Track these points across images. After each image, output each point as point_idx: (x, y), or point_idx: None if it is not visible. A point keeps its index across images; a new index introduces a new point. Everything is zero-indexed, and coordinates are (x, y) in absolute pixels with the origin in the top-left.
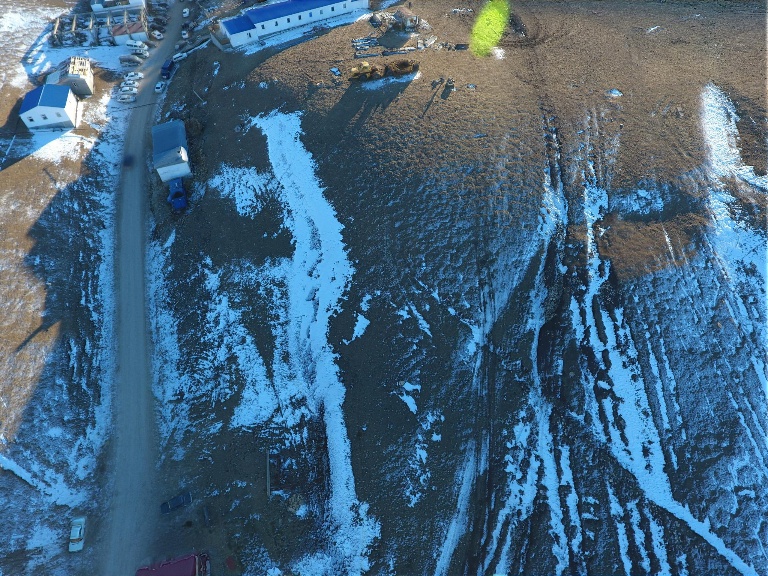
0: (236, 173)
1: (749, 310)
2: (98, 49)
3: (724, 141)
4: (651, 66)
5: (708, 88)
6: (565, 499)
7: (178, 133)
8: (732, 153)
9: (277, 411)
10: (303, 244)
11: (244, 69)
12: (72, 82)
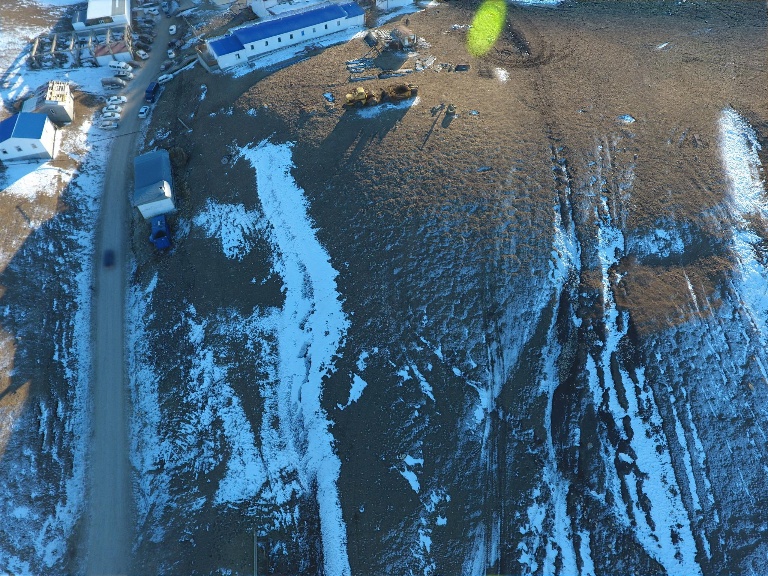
0: (223, 210)
1: None
2: (79, 71)
3: (746, 172)
4: (664, 88)
5: (726, 112)
6: None
7: (161, 165)
8: (755, 186)
9: (266, 485)
10: (294, 292)
11: (232, 94)
12: (50, 109)
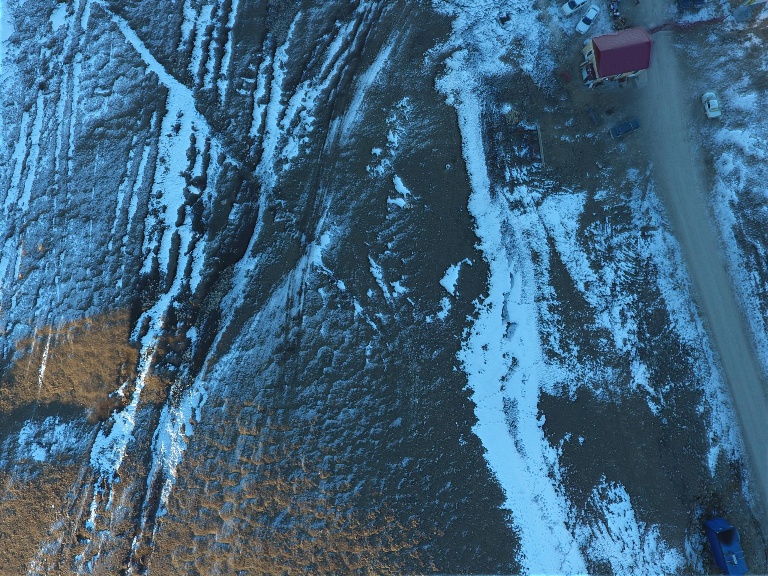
0: (645, 573)
1: None
2: None
3: None
4: None
5: None
6: (266, 94)
7: None
8: None
9: (538, 203)
10: (528, 411)
11: None
12: None
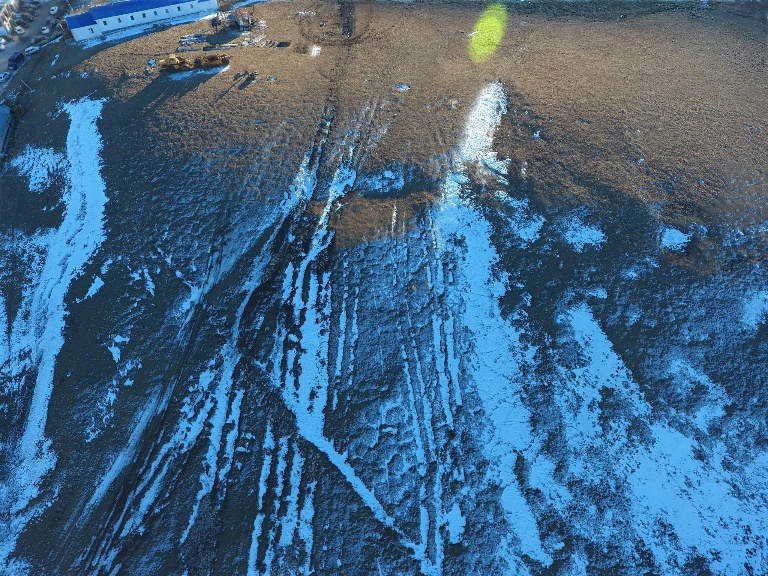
0: (36, 153)
1: (446, 275)
2: None
3: (484, 131)
4: (451, 65)
5: (491, 85)
6: (226, 435)
7: None
8: (486, 141)
9: (6, 363)
10: (71, 216)
11: (75, 61)
12: None
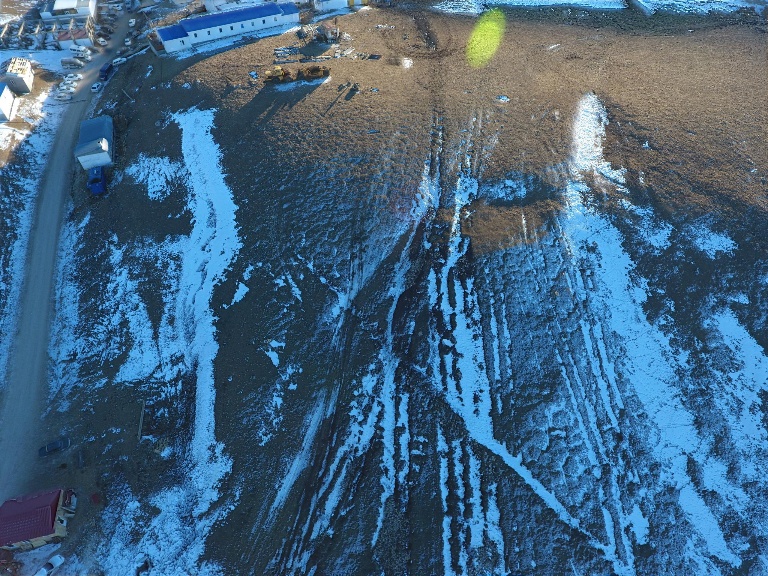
0: (151, 162)
1: (585, 281)
2: (42, 52)
3: (591, 141)
4: (542, 77)
5: (587, 96)
6: (399, 438)
7: (104, 127)
8: (596, 151)
9: (158, 368)
10: (201, 223)
11: (173, 72)
12: (10, 80)
